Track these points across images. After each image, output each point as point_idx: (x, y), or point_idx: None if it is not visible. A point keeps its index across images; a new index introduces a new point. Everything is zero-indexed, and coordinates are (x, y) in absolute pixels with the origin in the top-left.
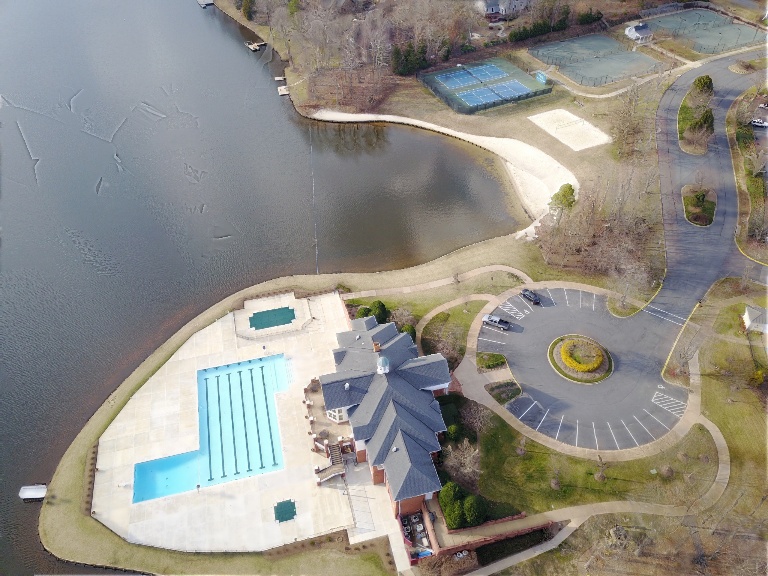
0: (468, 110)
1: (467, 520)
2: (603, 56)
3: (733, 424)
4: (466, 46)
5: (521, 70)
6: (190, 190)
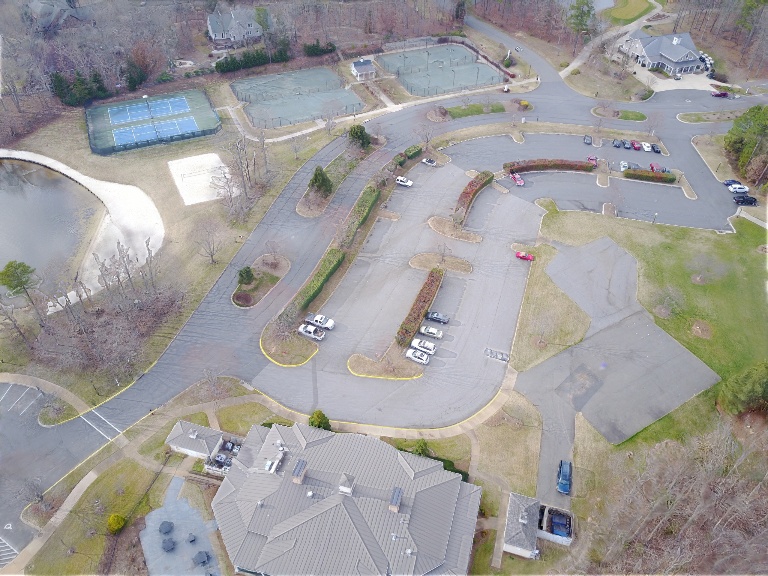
0: (101, 151)
1: None
2: (308, 93)
3: None
4: (163, 75)
5: (209, 105)
6: None
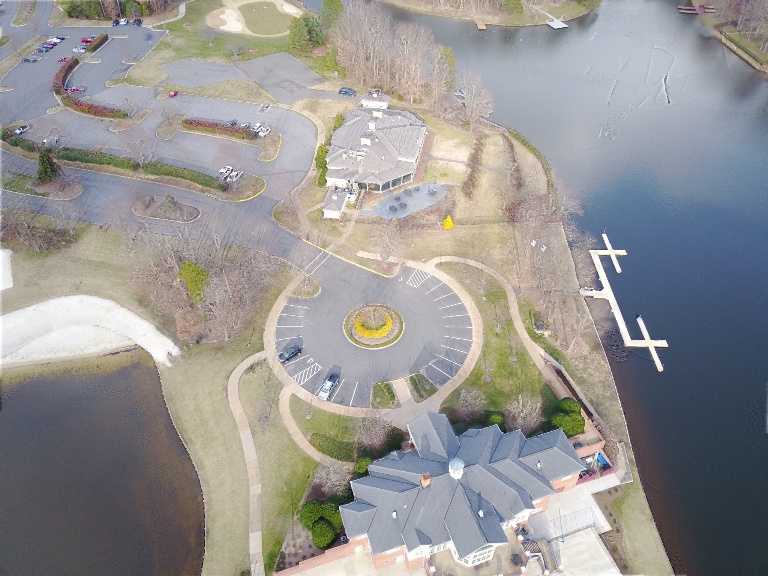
0: None
1: None
2: None
3: (433, 248)
4: None
5: None
6: None
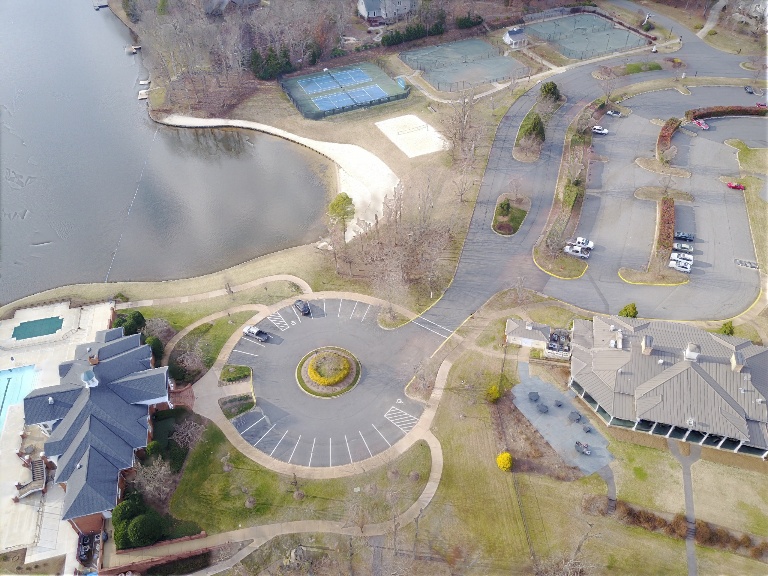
0: (314, 115)
1: (130, 540)
2: (472, 61)
3: (456, 440)
4: (336, 50)
5: (386, 75)
6: (11, 196)
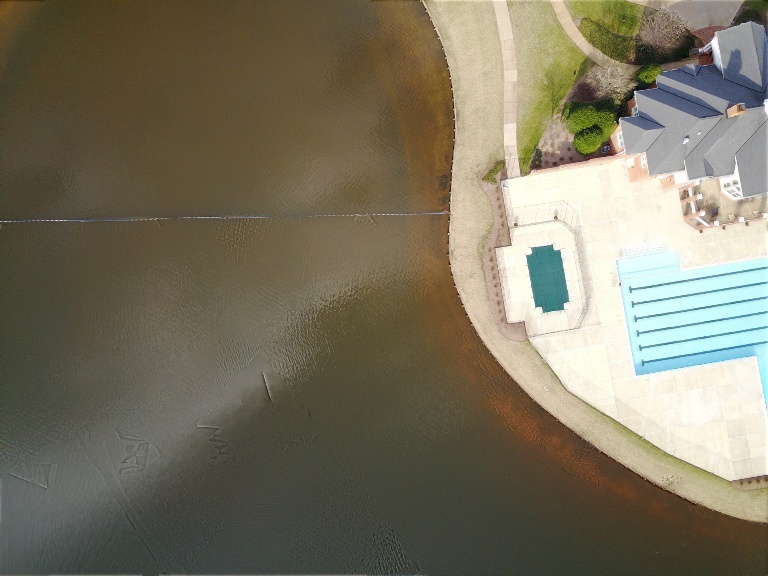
0: None
1: None
2: None
3: None
4: None
5: None
6: (177, 455)
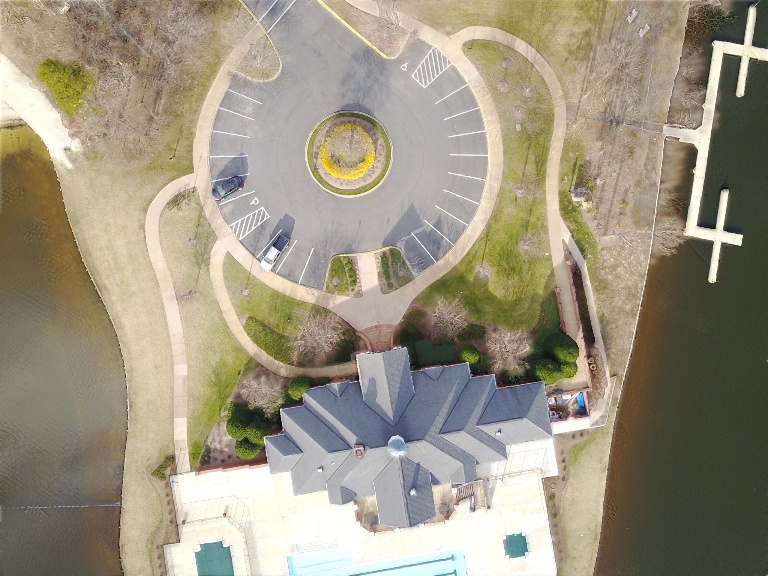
0: None
1: None
2: None
3: (469, 6)
4: None
5: None
6: None
